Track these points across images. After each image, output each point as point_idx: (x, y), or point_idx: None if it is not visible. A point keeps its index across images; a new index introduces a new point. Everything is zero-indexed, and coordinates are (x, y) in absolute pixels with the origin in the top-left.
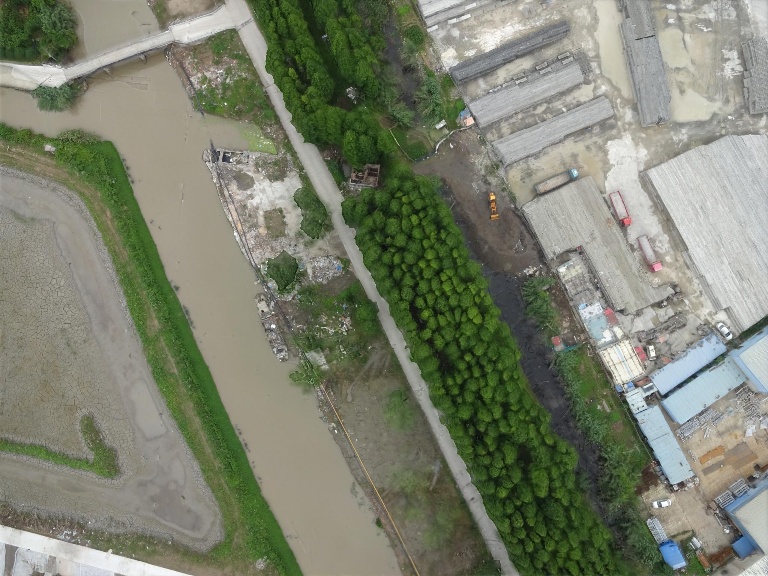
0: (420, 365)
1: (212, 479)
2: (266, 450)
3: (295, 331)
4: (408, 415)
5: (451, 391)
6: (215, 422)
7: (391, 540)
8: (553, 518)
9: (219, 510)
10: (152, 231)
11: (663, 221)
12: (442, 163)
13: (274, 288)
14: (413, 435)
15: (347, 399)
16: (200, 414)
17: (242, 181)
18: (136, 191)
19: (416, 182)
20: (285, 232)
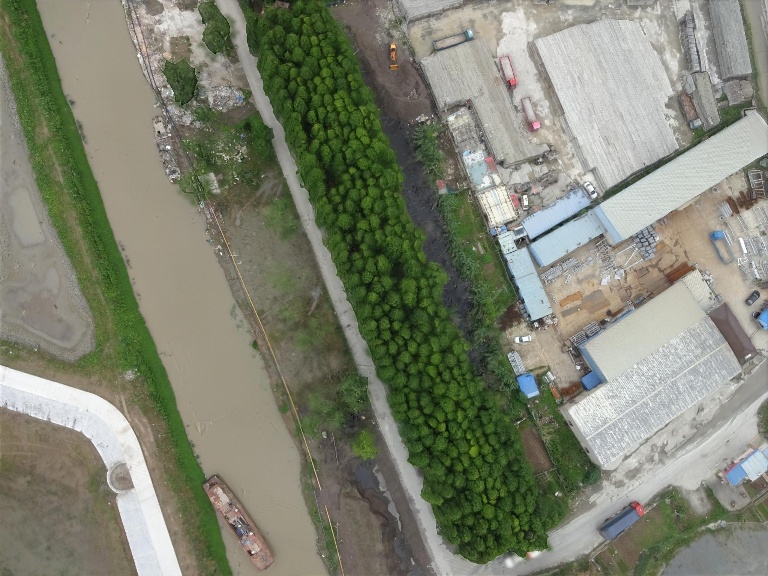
0: (307, 179)
1: (88, 289)
2: (148, 269)
3: (190, 154)
4: (294, 242)
5: (333, 201)
6: (98, 234)
7: (266, 362)
8: (418, 323)
9: (92, 321)
10: (52, 45)
11: (545, 88)
12: (349, 12)
13: (173, 112)
14: (297, 261)
15: (235, 223)
16: (82, 223)
17: (151, 6)
18: (40, 4)
19: (319, 6)
20: (190, 59)
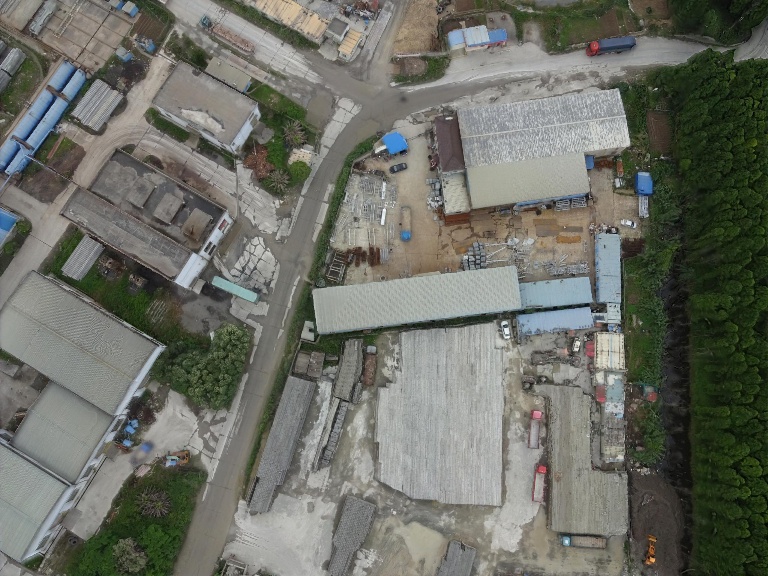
0: None
1: None
2: None
3: None
4: None
5: None
6: None
7: None
8: None
9: None
10: None
11: (504, 451)
12: None
13: None
14: None
15: None
16: None
17: None
18: None
19: None
20: None
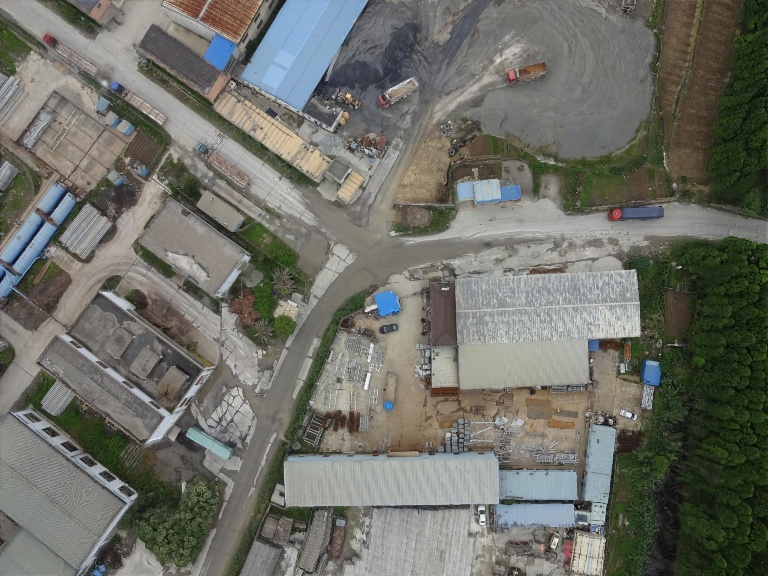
0: None
1: None
2: None
3: None
4: None
5: None
6: None
7: None
8: None
9: None
10: None
11: None
12: None
13: None
14: None
15: None
16: None
17: None
18: None
19: None
20: None
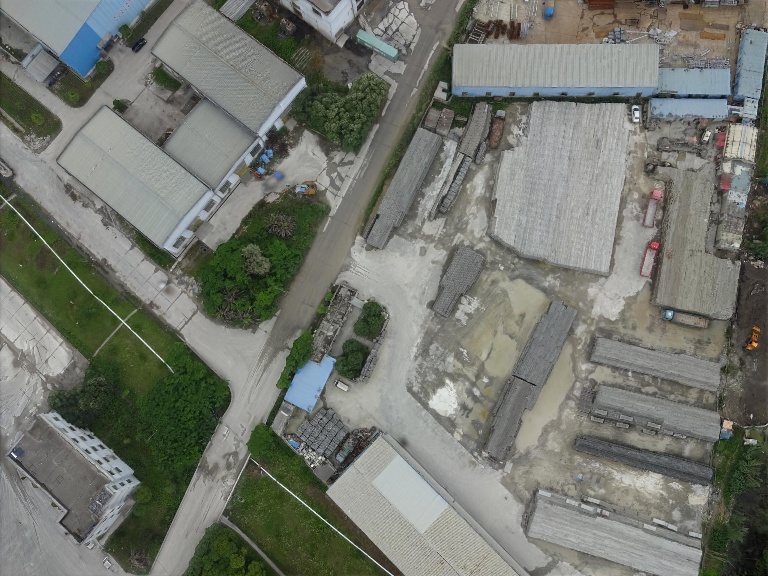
0: None
1: None
2: None
3: None
4: None
5: None
6: None
7: None
8: None
9: None
10: None
11: (618, 227)
12: None
13: None
14: None
15: None
16: None
17: None
18: None
19: None
20: None
